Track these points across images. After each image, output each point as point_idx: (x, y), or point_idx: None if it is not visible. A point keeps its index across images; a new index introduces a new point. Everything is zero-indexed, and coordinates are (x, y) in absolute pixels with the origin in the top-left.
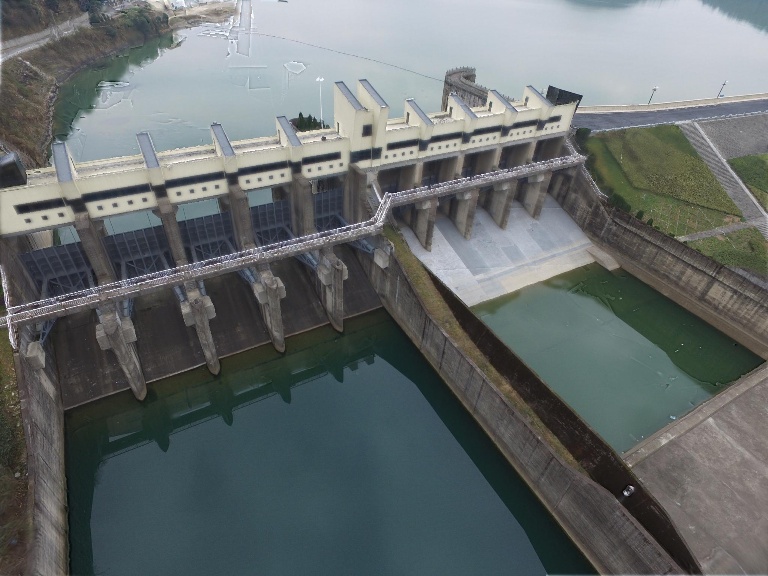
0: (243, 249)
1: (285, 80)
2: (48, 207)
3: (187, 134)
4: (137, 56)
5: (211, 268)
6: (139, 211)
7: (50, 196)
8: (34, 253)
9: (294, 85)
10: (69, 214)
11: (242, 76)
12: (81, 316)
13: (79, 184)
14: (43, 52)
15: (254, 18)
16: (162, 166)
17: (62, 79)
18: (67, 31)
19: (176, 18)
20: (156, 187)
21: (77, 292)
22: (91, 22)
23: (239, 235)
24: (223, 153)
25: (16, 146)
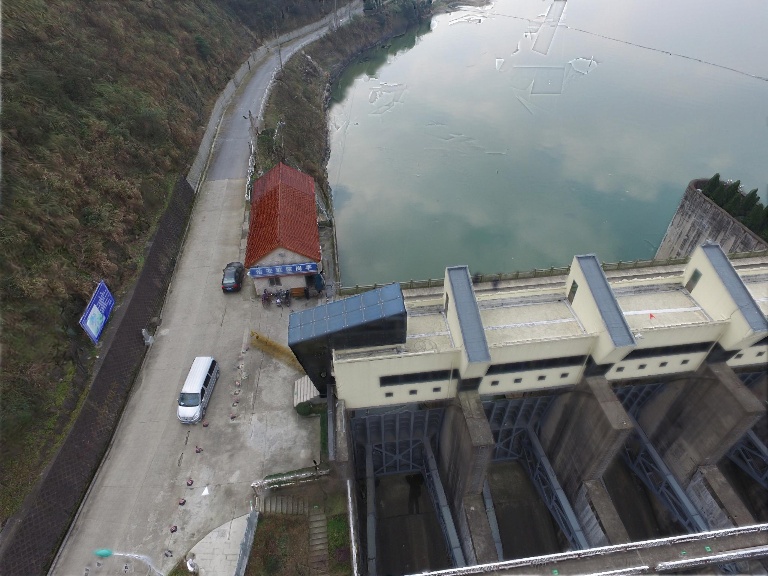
0: (678, 459)
1: (564, 80)
2: (425, 379)
3: (475, 159)
4: (397, 45)
5: (694, 561)
6: (545, 387)
7: (435, 366)
8: (370, 417)
9: (572, 87)
10: (449, 389)
11: (526, 78)
12: (397, 495)
13: None
14: (322, 44)
15: (565, 5)
16: None
17: (335, 74)
18: (341, 19)
19: (437, 1)
20: (599, 365)
21: (462, 569)
22: (365, 9)
23: (679, 435)
24: (748, 322)
25: (310, 174)
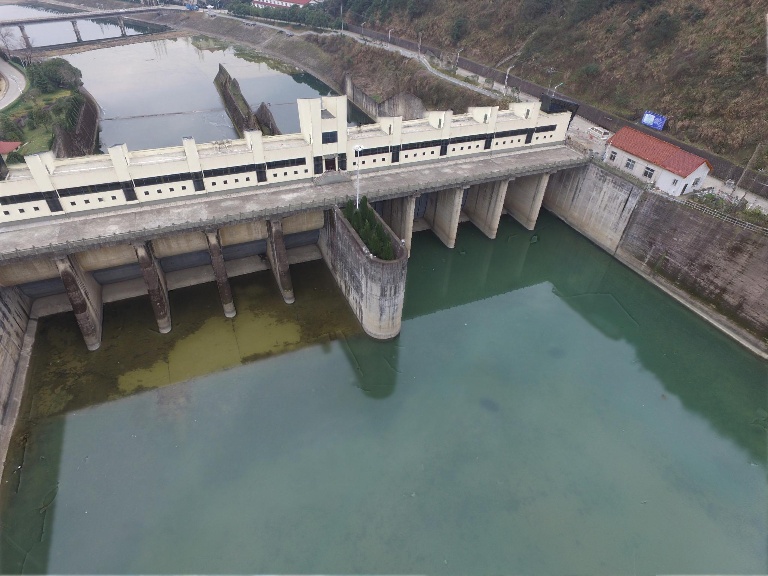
0: None
1: None
2: None
3: (722, 567)
4: None
5: None
6: None
7: None
8: None
9: None
10: None
11: None
12: None
13: (513, 112)
14: None
15: None
16: (472, 113)
17: None
18: None
19: None
20: None
21: None
22: None
23: None
24: None
25: None
